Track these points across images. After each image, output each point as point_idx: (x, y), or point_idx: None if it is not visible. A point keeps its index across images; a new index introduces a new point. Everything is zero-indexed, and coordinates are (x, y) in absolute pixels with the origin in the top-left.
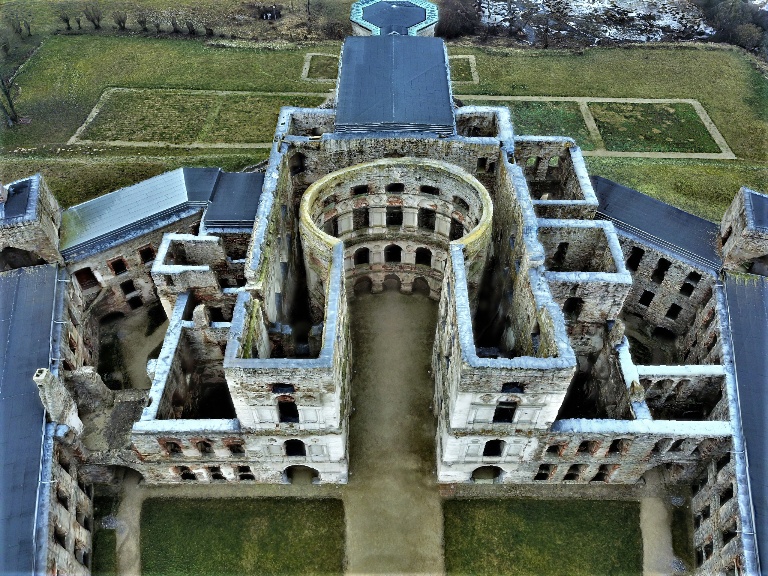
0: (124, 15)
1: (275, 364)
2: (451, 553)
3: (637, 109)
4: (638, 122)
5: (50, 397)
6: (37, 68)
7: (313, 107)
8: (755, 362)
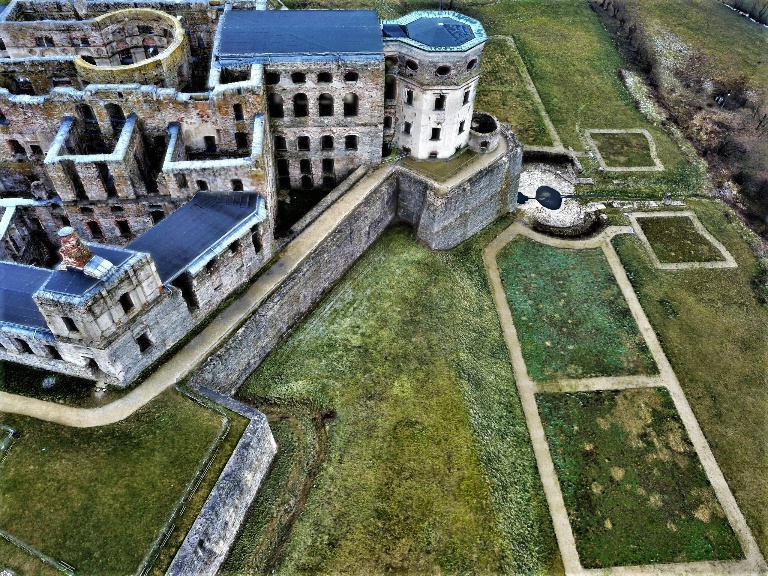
0: (628, 17)
1: (6, 9)
2: None
3: (678, 457)
4: (634, 450)
5: (75, 4)
6: (525, 4)
7: (530, 139)
8: None
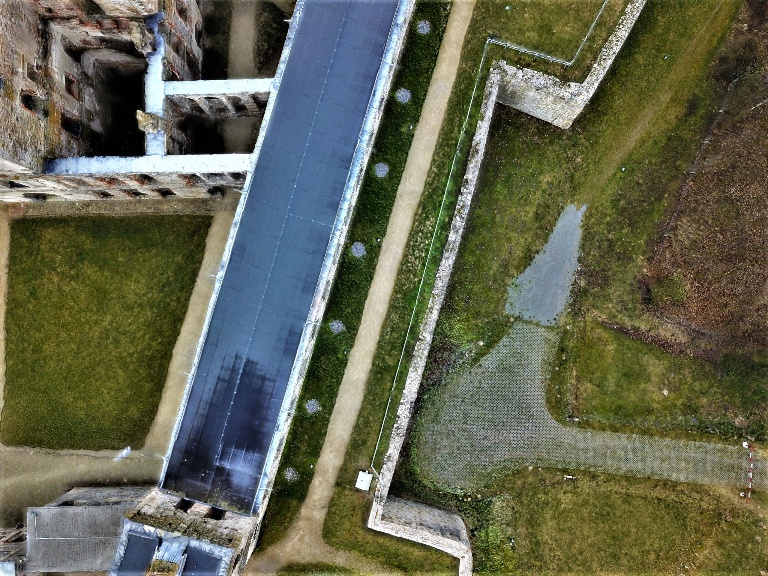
0: None
1: None
2: (14, 272)
3: None
4: None
5: None
6: None
7: None
8: (304, 76)
